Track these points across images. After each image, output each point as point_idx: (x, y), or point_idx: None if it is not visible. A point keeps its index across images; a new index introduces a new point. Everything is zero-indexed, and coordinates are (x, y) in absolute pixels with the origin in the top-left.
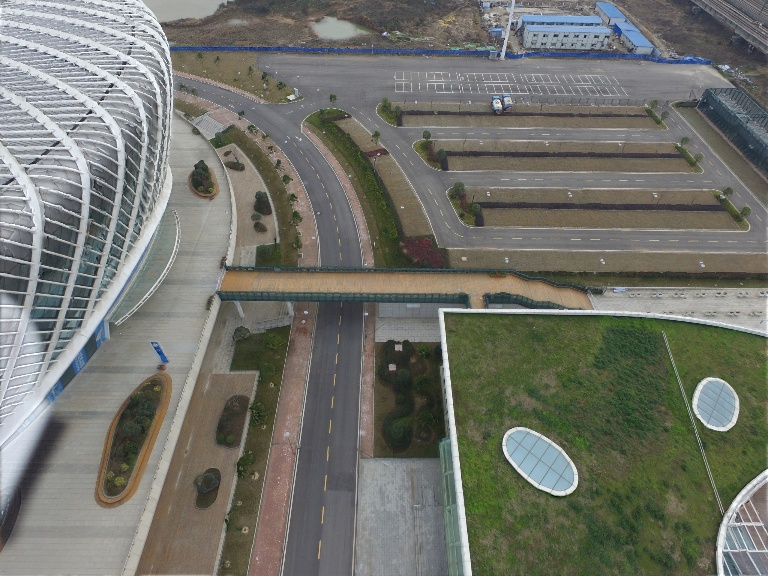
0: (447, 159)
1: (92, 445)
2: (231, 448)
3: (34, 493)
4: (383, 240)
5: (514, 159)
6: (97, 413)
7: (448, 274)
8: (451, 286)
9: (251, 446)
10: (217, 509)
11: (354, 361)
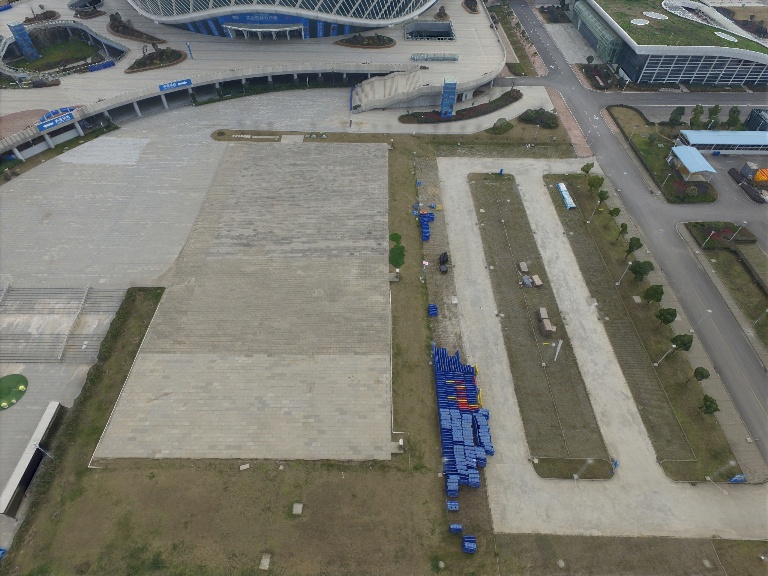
0: None
1: None
2: None
3: (449, 12)
4: None
5: None
6: None
7: None
8: None
9: None
10: None
11: (530, 11)
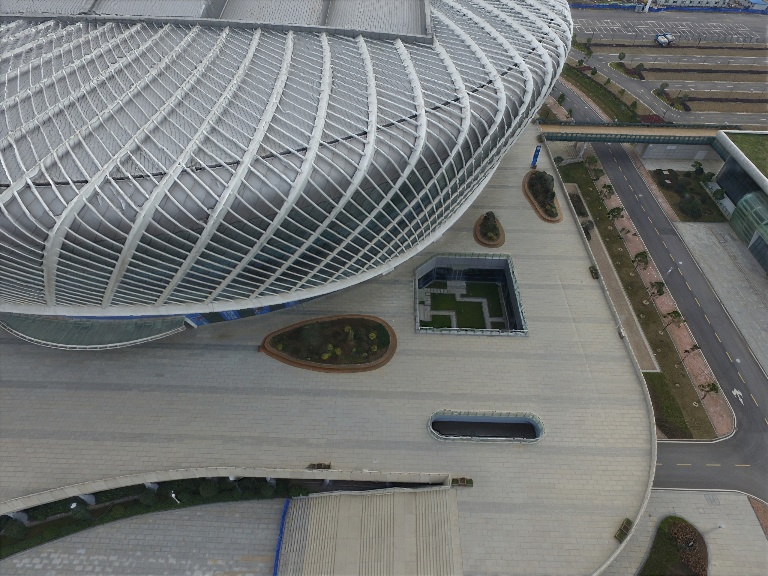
0: (641, 73)
1: (519, 199)
2: (584, 217)
3: (503, 217)
4: (621, 118)
5: (692, 74)
6: (510, 186)
7: (691, 129)
8: (697, 134)
9: (597, 216)
10: (595, 242)
11: (638, 179)
